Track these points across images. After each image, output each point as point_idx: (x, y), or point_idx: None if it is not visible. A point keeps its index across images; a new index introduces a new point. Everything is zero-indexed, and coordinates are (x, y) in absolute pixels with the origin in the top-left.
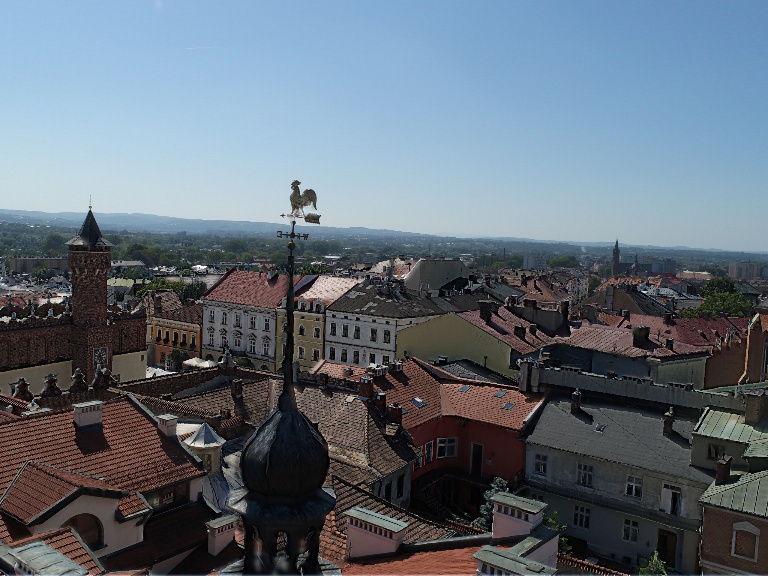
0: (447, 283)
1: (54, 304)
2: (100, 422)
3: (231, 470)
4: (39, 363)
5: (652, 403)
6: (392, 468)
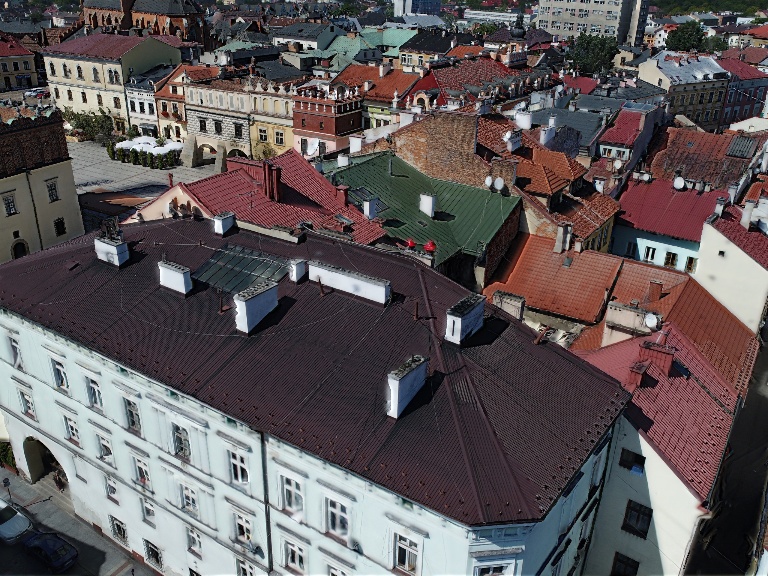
0: None
1: None
2: None
3: None
4: None
5: (267, 56)
6: None
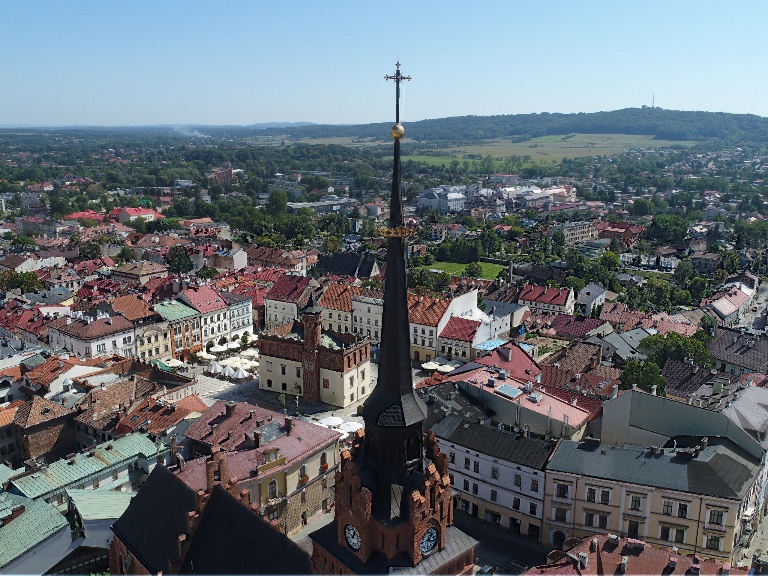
0: (691, 435)
1: (351, 334)
2: (62, 367)
3: (72, 394)
4: (294, 359)
5: None
6: (97, 426)
